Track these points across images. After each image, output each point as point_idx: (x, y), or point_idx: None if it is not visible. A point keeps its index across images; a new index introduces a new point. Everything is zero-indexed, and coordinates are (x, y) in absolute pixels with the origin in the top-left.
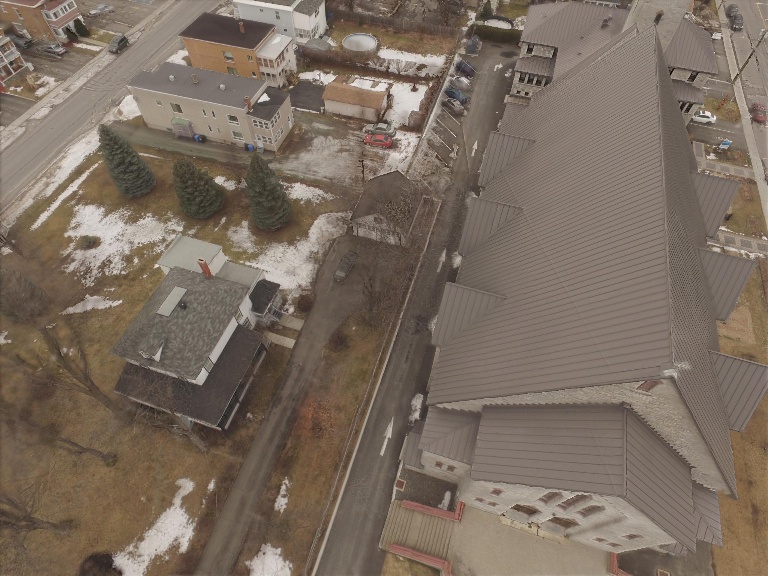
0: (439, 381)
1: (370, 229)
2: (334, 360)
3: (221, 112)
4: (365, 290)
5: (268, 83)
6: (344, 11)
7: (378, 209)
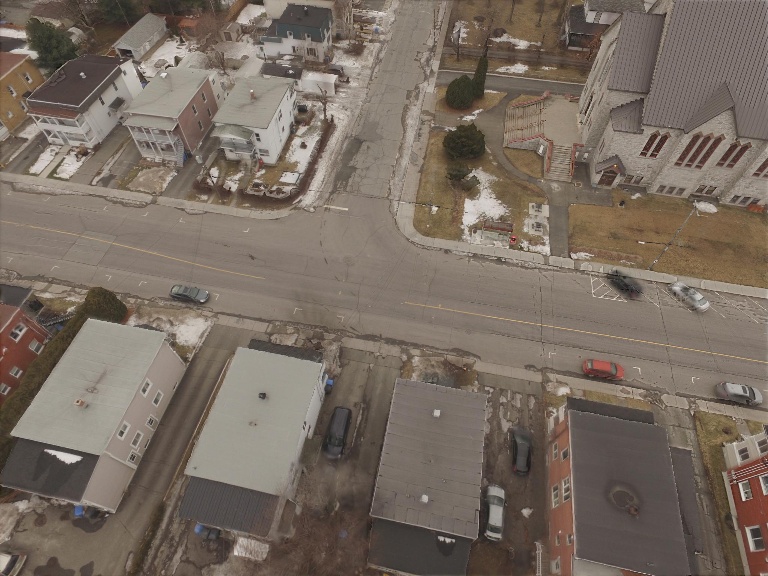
0: None
1: None
2: None
3: None
4: None
5: None
6: None
7: None
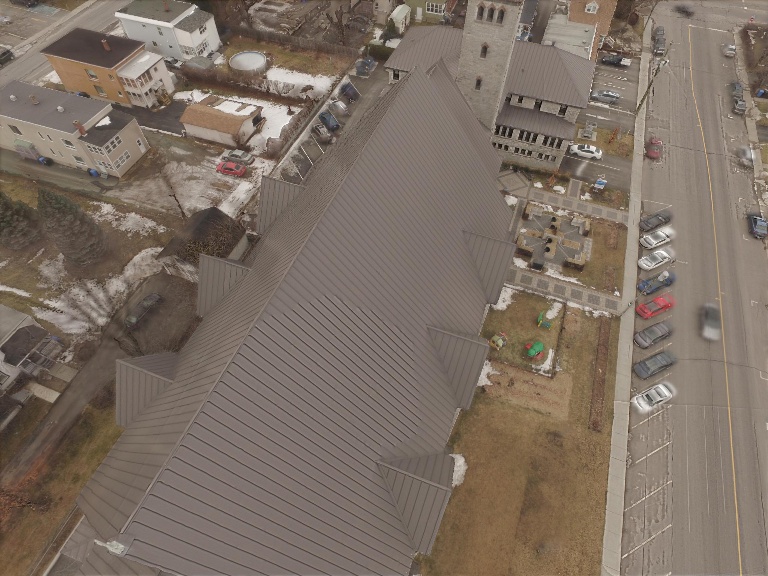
0: (94, 475)
1: (179, 269)
2: (94, 418)
3: (55, 136)
4: (121, 345)
5: (136, 103)
6: (241, 27)
7: (176, 250)
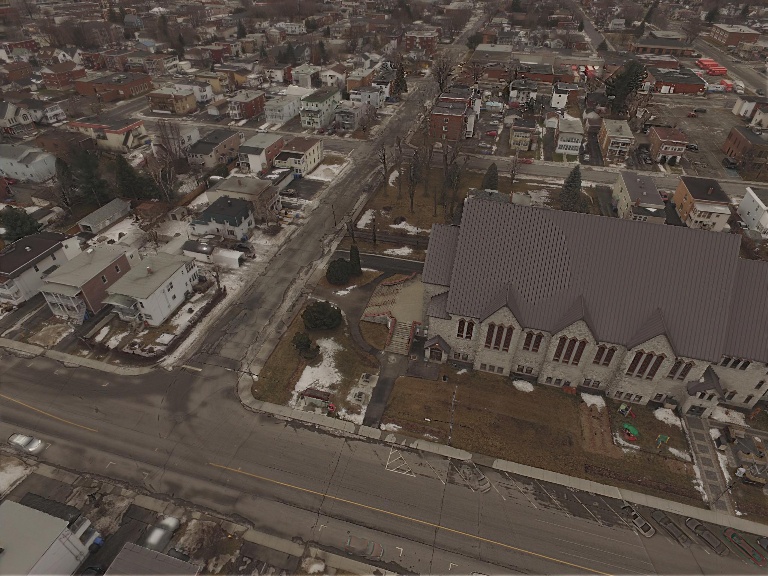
0: None
1: None
2: None
3: None
4: None
5: None
6: None
7: None
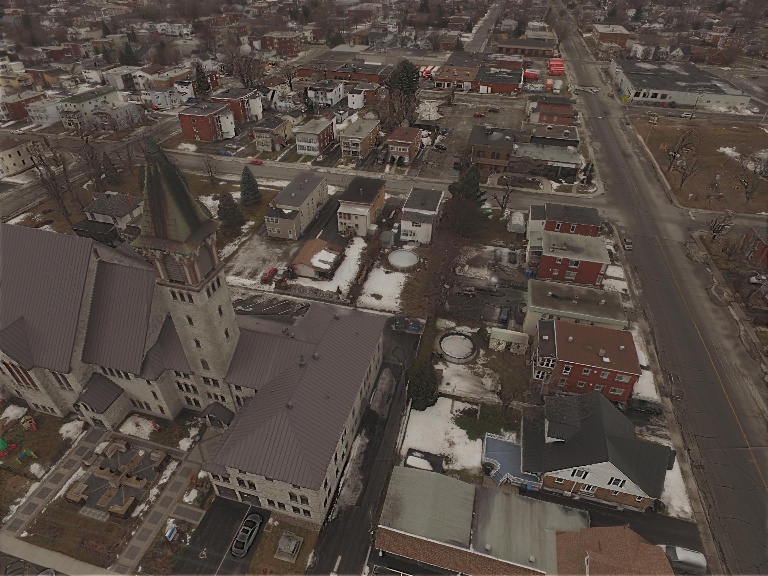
0: None
1: None
2: None
3: None
4: None
5: None
6: None
7: None
